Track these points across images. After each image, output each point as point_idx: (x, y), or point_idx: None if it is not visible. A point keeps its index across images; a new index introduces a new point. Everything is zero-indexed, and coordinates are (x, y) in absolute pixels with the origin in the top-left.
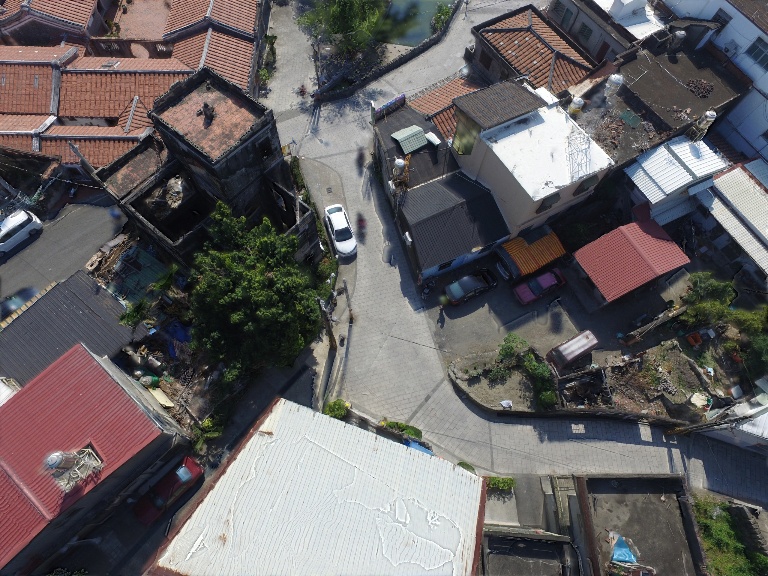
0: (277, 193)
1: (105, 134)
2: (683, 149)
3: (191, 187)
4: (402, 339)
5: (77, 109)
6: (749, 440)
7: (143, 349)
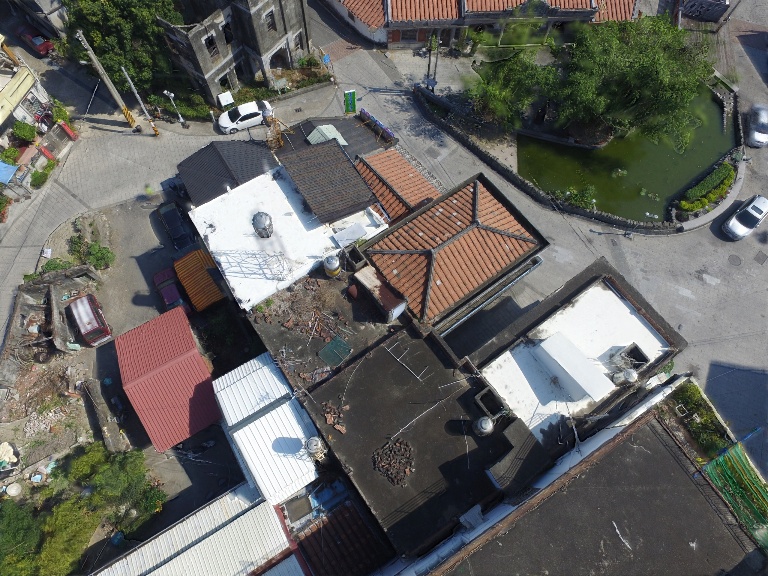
0: None
1: None
2: (287, 425)
3: None
4: None
5: None
6: None
7: None
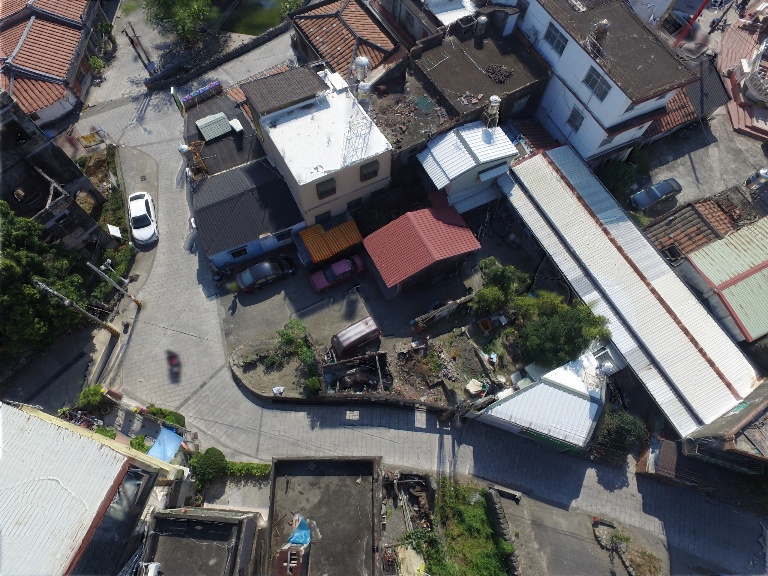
0: None
1: None
2: (474, 135)
3: None
4: (151, 324)
5: None
6: None
7: None
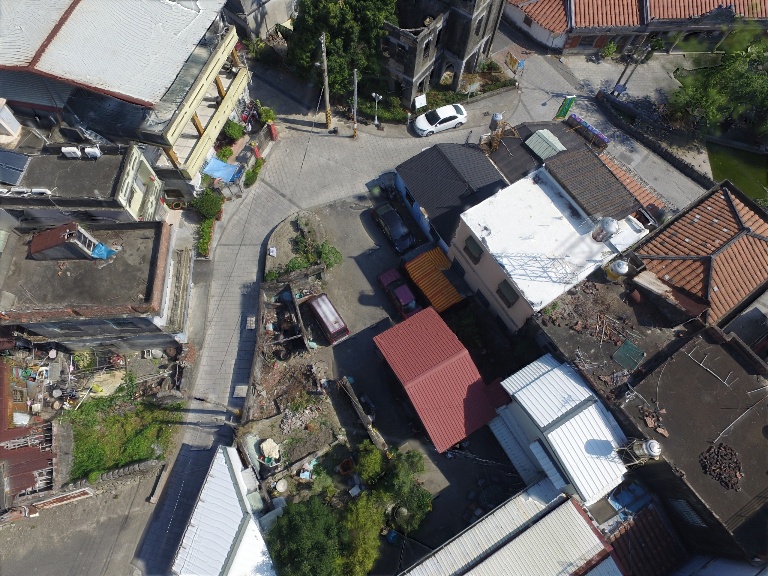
0: None
1: None
2: (596, 427)
3: None
4: None
5: None
6: None
7: None
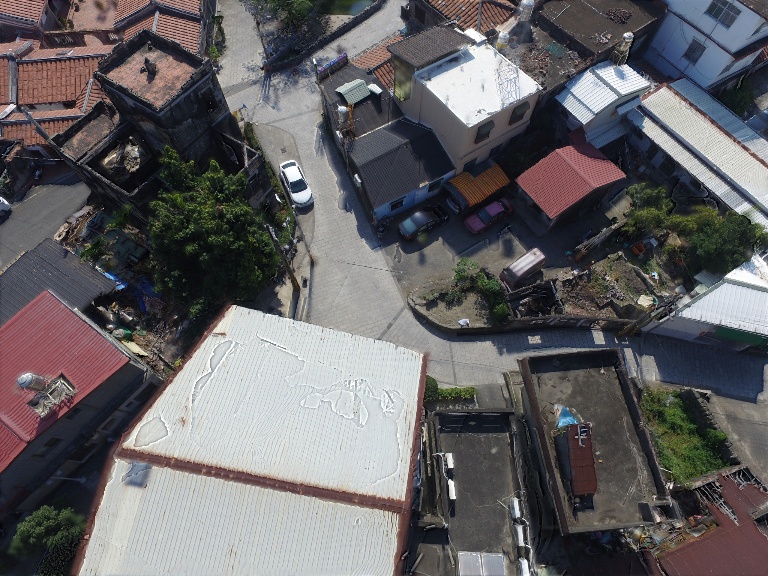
0: (227, 145)
1: (63, 115)
2: (608, 72)
3: (147, 151)
4: None
5: (35, 96)
6: (693, 330)
7: (114, 306)
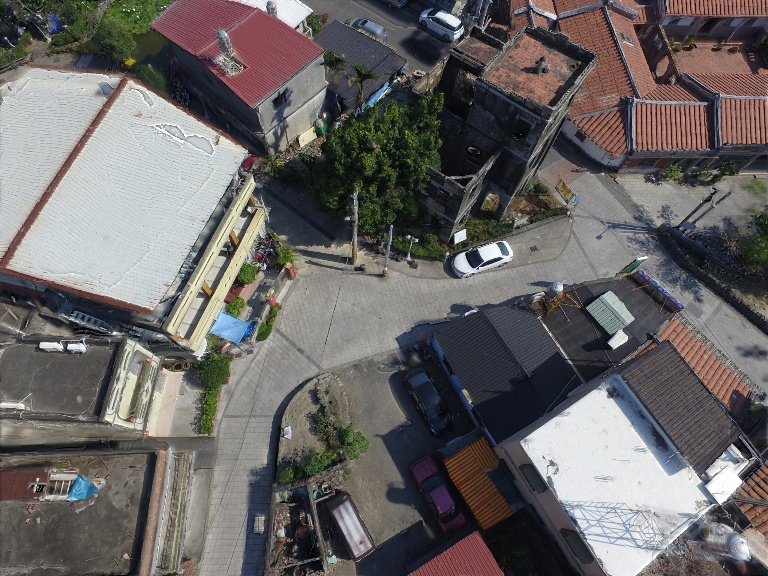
0: None
1: None
2: None
3: None
4: None
5: (569, 30)
6: None
7: (346, 117)
